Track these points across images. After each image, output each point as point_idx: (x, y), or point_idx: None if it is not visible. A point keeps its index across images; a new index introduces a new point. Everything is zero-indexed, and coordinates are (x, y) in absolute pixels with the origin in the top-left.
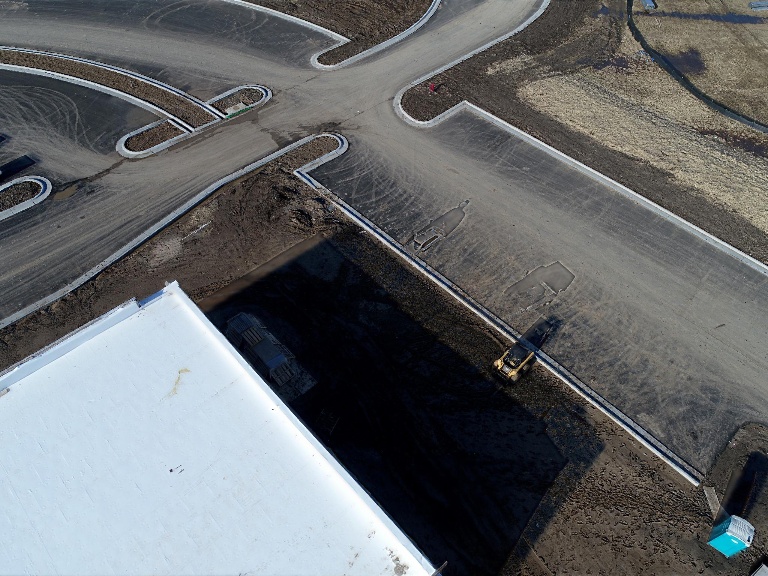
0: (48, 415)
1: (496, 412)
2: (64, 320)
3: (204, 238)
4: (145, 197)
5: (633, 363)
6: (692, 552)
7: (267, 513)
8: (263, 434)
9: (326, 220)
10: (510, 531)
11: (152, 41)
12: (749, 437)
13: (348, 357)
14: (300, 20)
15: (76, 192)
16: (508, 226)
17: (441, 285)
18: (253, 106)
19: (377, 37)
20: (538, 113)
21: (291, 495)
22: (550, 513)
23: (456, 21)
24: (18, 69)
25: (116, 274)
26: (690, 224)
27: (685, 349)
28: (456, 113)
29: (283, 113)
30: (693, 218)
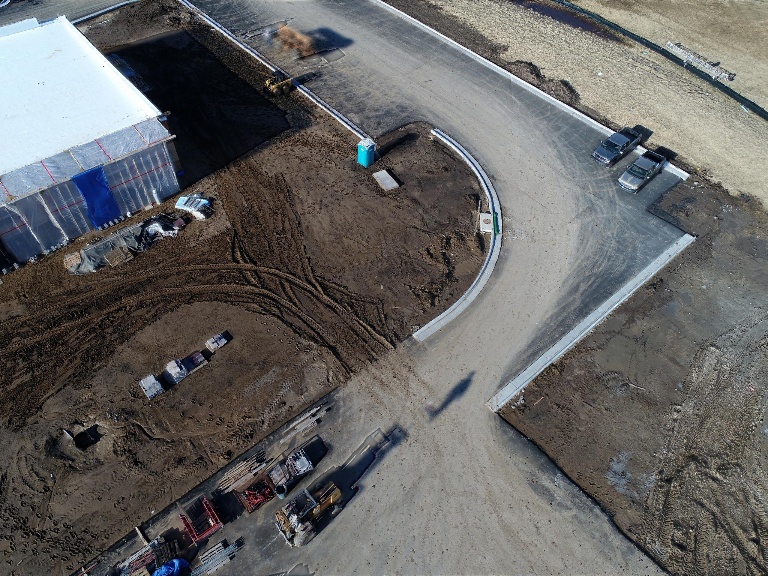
0: None
1: (258, 106)
2: None
3: (104, 26)
4: (72, 8)
5: (360, 94)
6: (346, 165)
7: (86, 100)
8: (95, 75)
9: (190, 22)
10: (242, 150)
11: None
12: (414, 127)
13: (176, 80)
14: None
15: (26, 3)
16: (314, 31)
17: (253, 54)
18: None
19: None
20: None
21: (101, 95)
22: (270, 146)
23: None
24: None
25: None
26: (439, 33)
27: (398, 90)
28: None
29: None
30: (443, 30)
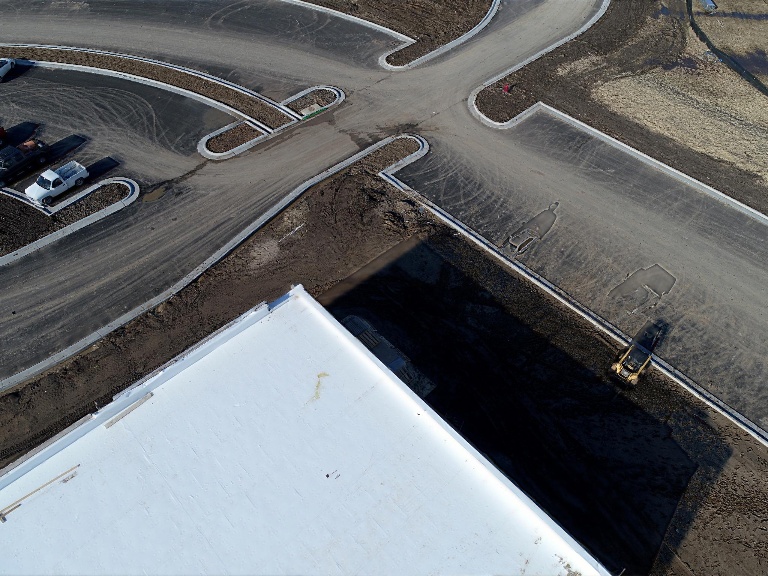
0: (196, 419)
1: (619, 416)
2: (173, 323)
3: (300, 240)
4: (234, 199)
5: (747, 367)
6: None
7: (430, 519)
8: (412, 439)
9: (419, 222)
10: (651, 536)
11: (218, 42)
12: None
13: (463, 360)
14: (363, 20)
15: (164, 194)
16: (601, 228)
17: (544, 288)
18: (328, 107)
19: (442, 38)
20: (615, 114)
21: (451, 501)
22: (688, 518)
23: (518, 21)
24: (88, 70)
25: (217, 276)
26: None
27: None
28: (532, 114)
29: (359, 114)
30: None
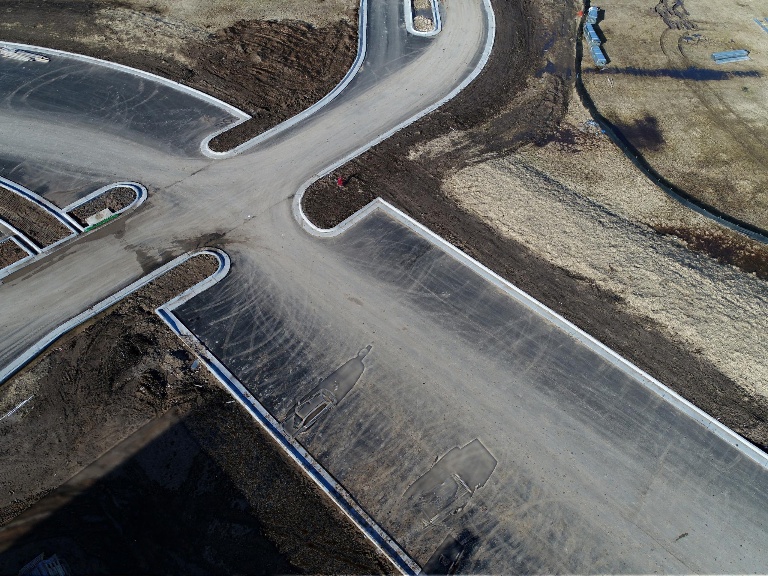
0: None
1: None
2: None
3: (19, 424)
4: None
5: None
6: None
7: None
8: None
9: (184, 386)
10: None
11: (13, 125)
12: None
13: None
14: (195, 91)
15: None
16: (417, 384)
17: (322, 487)
18: (121, 212)
19: (283, 112)
20: (464, 213)
21: None
22: None
23: (378, 87)
24: None
25: None
26: (644, 373)
27: None
28: (367, 215)
29: (156, 221)
30: (647, 364)
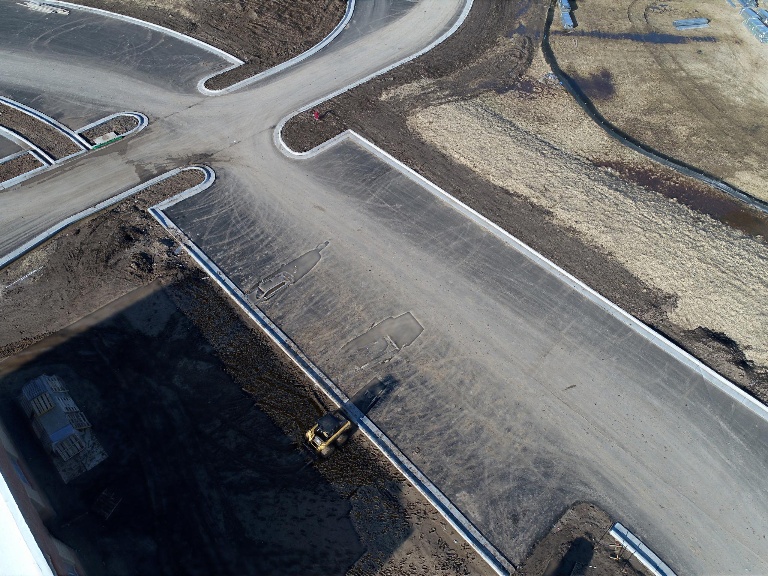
0: None
1: (298, 491)
2: None
3: (30, 286)
4: None
5: (465, 431)
6: None
7: None
8: None
9: (168, 265)
10: None
11: (35, 64)
12: (577, 520)
13: (150, 426)
14: (197, 41)
15: None
16: (364, 271)
17: (274, 340)
18: (125, 135)
19: (273, 59)
20: (423, 143)
21: None
22: None
23: (361, 42)
24: None
25: None
26: (560, 269)
27: (526, 414)
28: (337, 143)
29: (154, 143)
30: (564, 262)
